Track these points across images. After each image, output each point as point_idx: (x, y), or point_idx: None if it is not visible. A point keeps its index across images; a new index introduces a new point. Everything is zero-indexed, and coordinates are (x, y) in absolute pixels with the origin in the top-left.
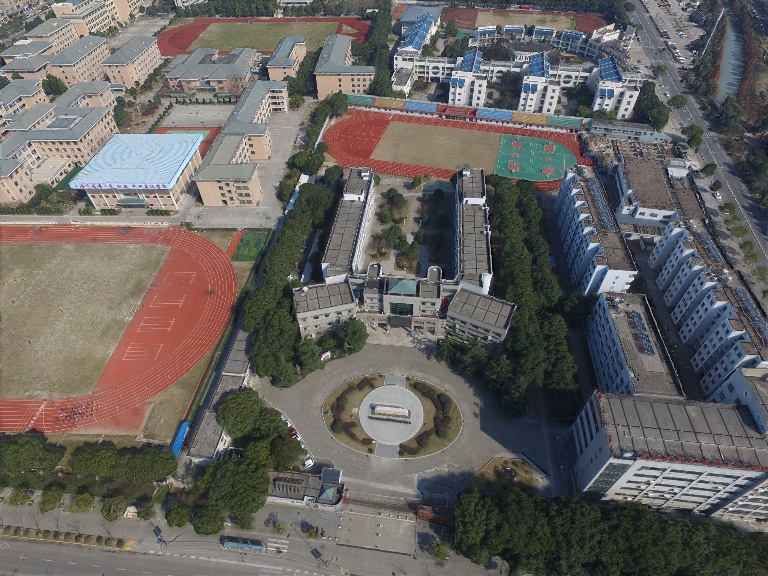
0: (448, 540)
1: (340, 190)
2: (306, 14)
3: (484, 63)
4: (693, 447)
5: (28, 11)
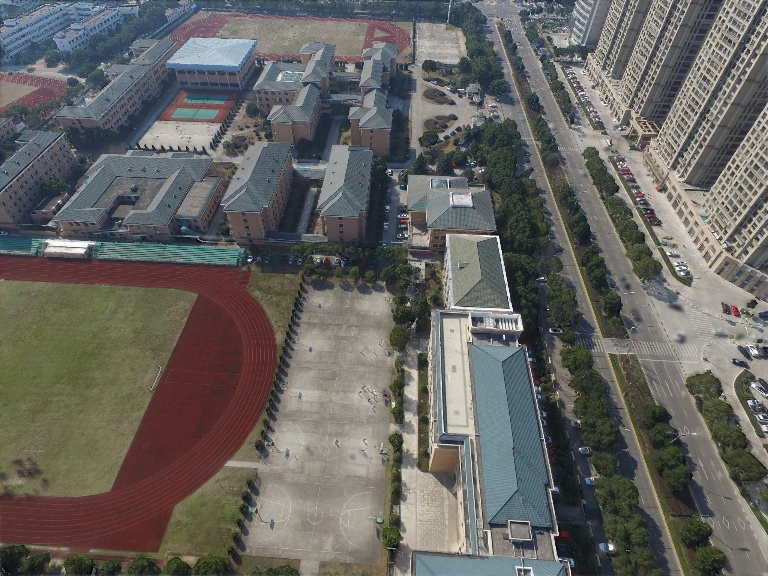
0: None
1: None
2: None
3: None
4: None
5: None
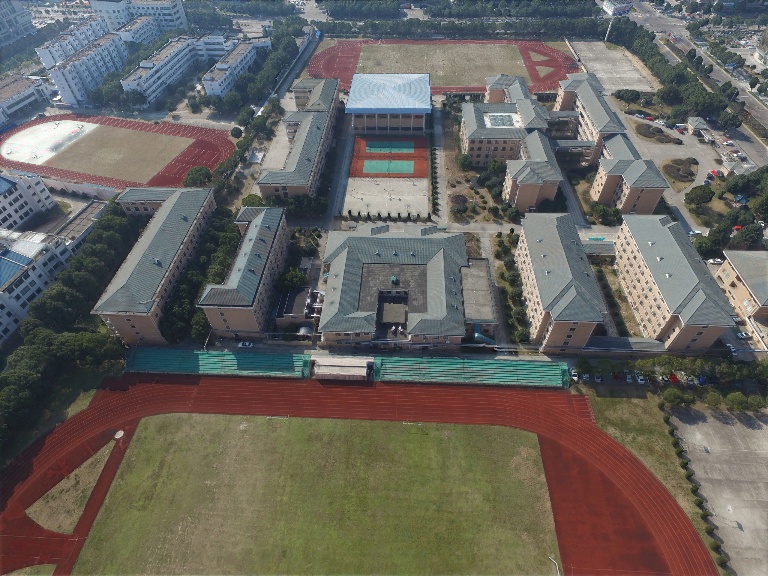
0: None
1: None
2: None
3: None
4: None
5: None
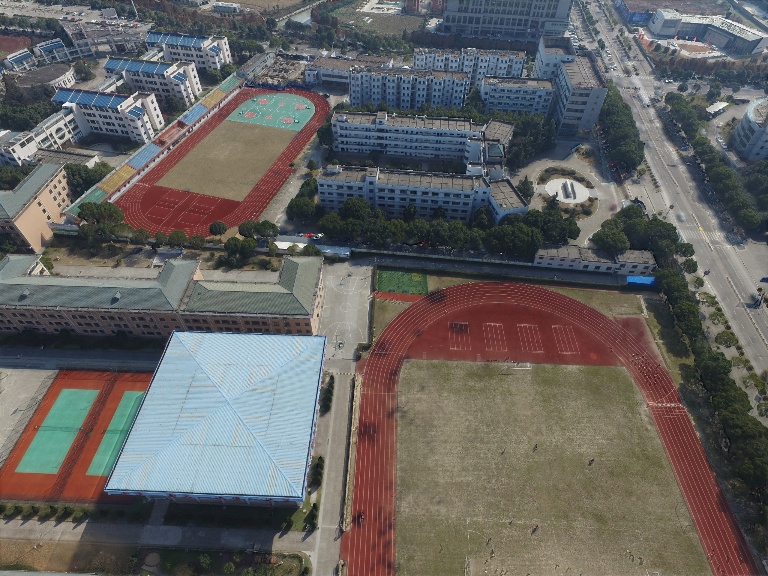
0: (630, 175)
1: (323, 209)
2: None
3: None
4: (589, 74)
5: None
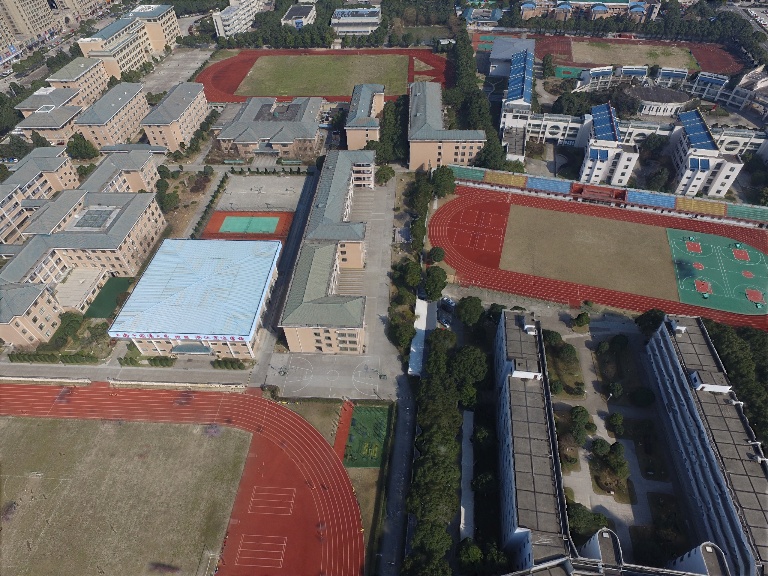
0: None
1: (481, 335)
2: (368, 45)
3: (621, 124)
4: None
5: (50, 40)
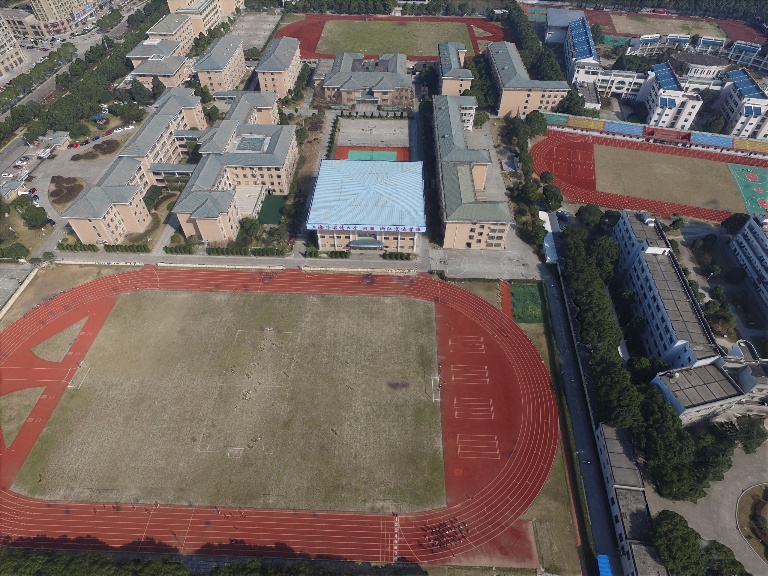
0: None
1: (602, 233)
2: (426, 13)
3: (680, 79)
4: None
5: (116, 1)
